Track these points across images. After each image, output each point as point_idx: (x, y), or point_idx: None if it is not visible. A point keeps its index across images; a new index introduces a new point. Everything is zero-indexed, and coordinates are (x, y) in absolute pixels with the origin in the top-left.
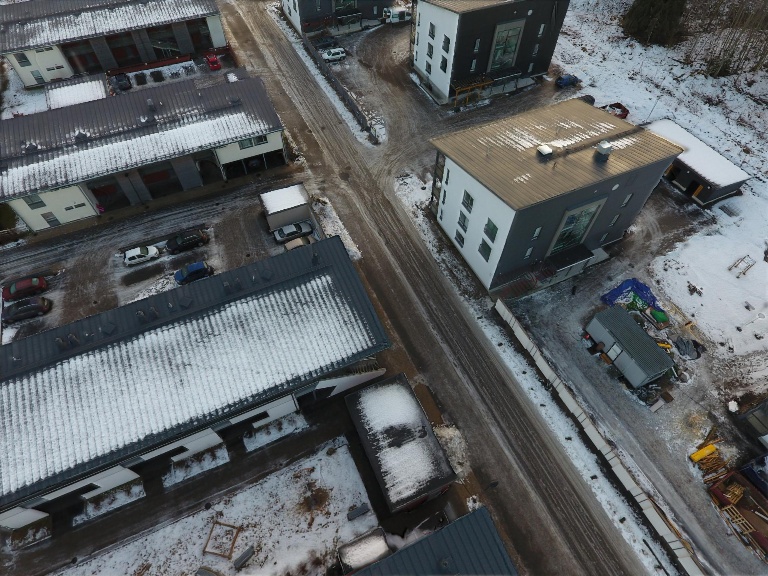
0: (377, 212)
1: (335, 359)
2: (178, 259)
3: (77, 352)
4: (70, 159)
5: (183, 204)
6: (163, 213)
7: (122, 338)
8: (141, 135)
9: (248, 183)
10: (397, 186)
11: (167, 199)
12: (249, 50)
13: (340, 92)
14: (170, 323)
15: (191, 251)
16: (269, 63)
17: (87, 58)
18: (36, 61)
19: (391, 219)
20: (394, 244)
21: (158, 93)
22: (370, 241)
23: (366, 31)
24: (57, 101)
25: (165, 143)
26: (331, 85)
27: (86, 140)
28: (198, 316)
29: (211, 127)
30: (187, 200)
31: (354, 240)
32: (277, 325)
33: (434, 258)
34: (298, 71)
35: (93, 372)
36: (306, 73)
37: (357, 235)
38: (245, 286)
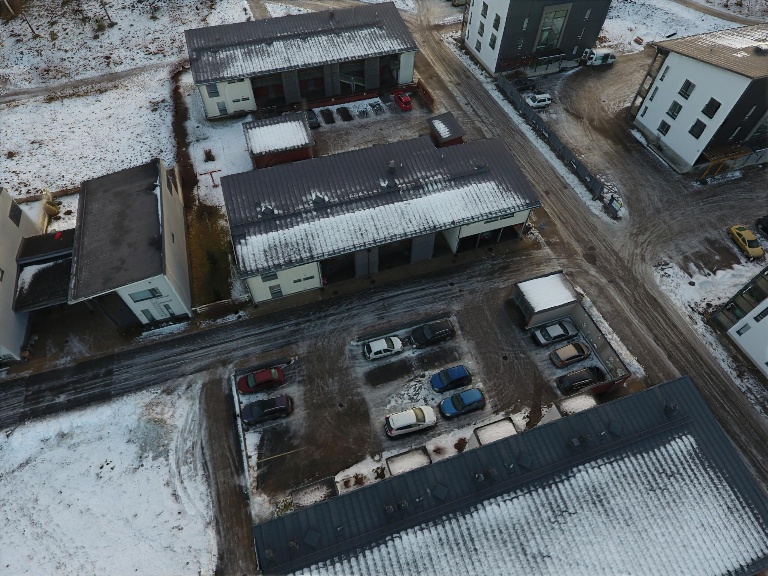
0: (645, 312)
1: (732, 566)
2: (425, 356)
3: (410, 524)
4: (311, 229)
5: (413, 281)
6: (393, 291)
7: (459, 508)
8: (384, 203)
9: (481, 259)
10: (659, 278)
11: (393, 272)
12: (437, 88)
13: (556, 148)
14: (512, 490)
15: (438, 346)
16: (463, 106)
17: (269, 89)
18: (225, 92)
19: (665, 324)
20: (680, 360)
21: (394, 151)
22: (649, 353)
23: (564, 73)
24: (258, 143)
25: (412, 215)
26: (542, 138)
27: (326, 206)
28: (543, 482)
29: (460, 198)
30: (416, 276)
31: (629, 349)
32: (645, 505)
33: (737, 385)
34: (498, 118)
35: (433, 556)
36: (508, 121)
37: (631, 343)
38: (591, 442)
